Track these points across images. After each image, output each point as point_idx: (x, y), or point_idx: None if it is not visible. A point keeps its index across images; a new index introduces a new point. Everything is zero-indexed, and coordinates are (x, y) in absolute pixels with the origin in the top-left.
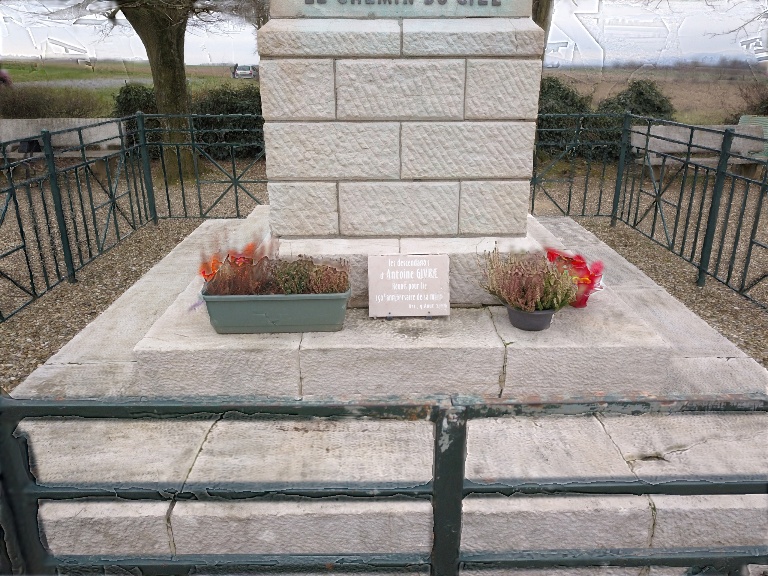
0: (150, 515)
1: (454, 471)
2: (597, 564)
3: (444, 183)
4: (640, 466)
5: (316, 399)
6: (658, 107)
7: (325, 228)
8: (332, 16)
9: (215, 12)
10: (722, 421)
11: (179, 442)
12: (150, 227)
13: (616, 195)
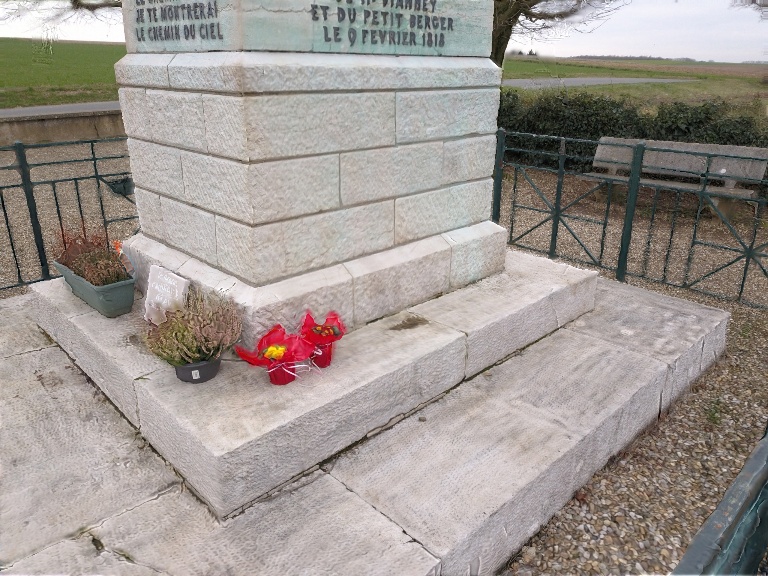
0: None
1: None
2: None
3: (205, 213)
4: (80, 541)
5: (80, 364)
6: None
7: (159, 233)
8: None
9: (539, 19)
10: (221, 574)
11: None
12: None
13: None
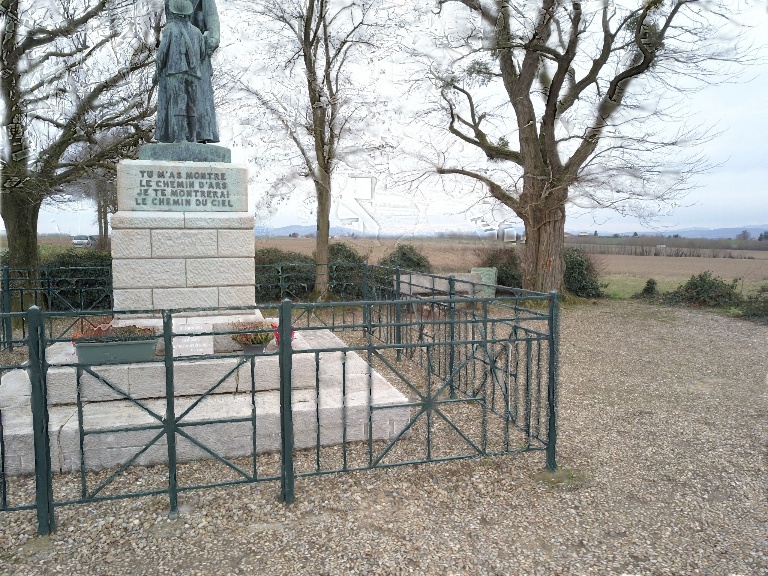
0: (50, 431)
1: (168, 327)
2: (213, 358)
3: (210, 288)
4: None
5: (137, 397)
6: (418, 263)
7: None
8: (150, 210)
9: (67, 195)
10: None
11: (60, 414)
12: (6, 353)
13: (364, 316)
